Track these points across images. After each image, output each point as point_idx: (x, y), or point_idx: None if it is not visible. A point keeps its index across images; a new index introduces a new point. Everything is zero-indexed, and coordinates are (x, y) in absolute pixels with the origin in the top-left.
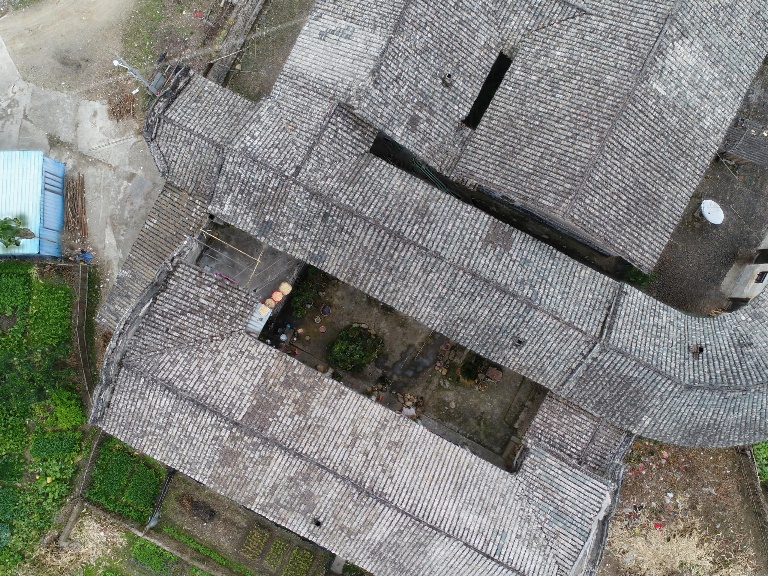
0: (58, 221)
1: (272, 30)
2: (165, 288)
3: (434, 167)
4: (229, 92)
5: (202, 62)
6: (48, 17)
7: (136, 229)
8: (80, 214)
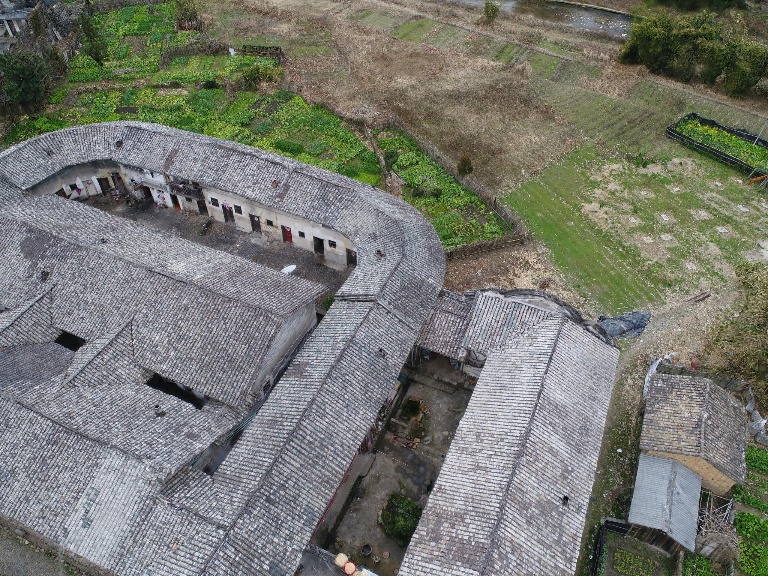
0: None
1: None
2: None
3: (233, 426)
4: None
5: None
6: None
7: None
8: None
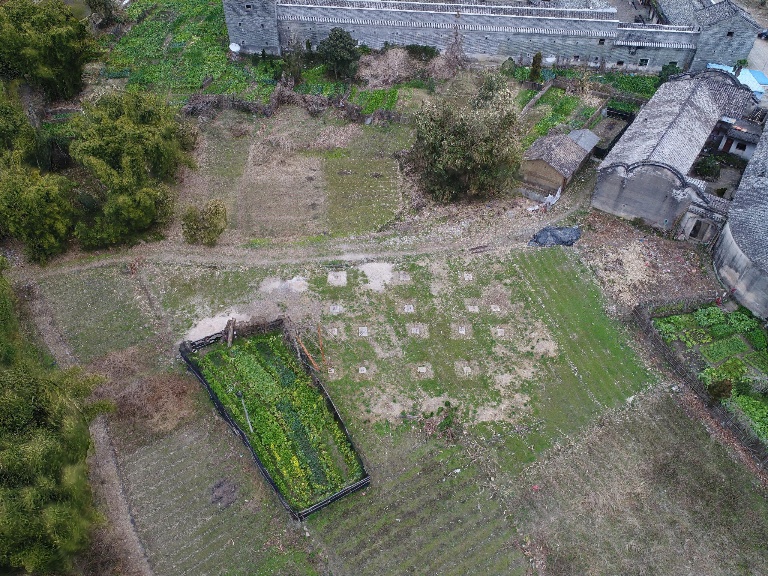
0: None
1: None
2: (739, 89)
3: None
4: None
5: None
6: None
7: None
8: None
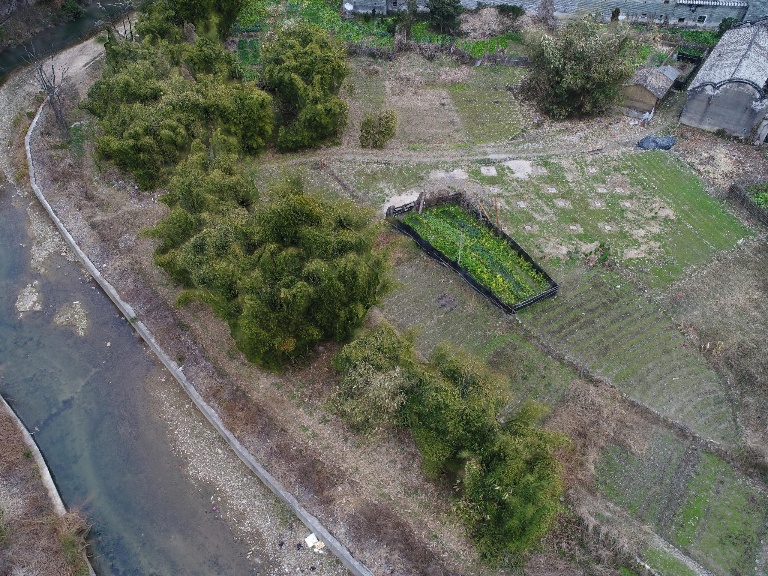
0: None
1: None
2: None
3: None
4: None
5: None
6: None
7: None
8: None
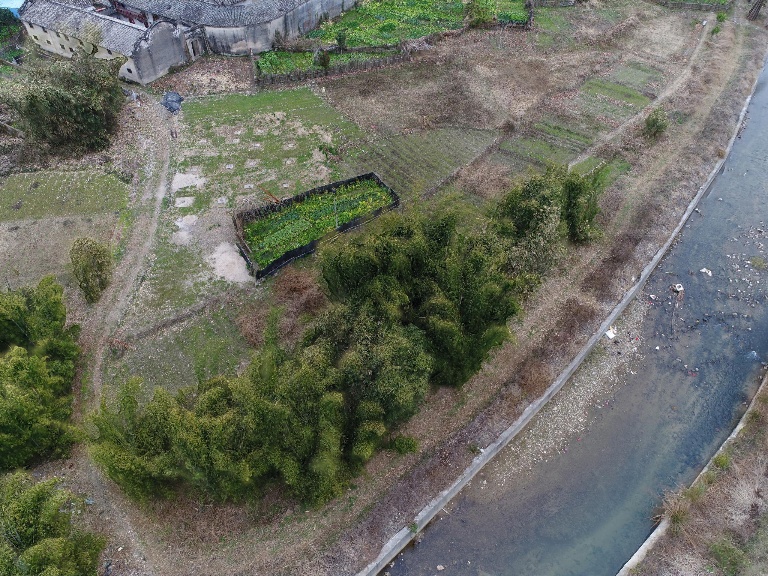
0: None
1: None
2: None
3: None
4: None
5: None
6: None
7: None
8: None
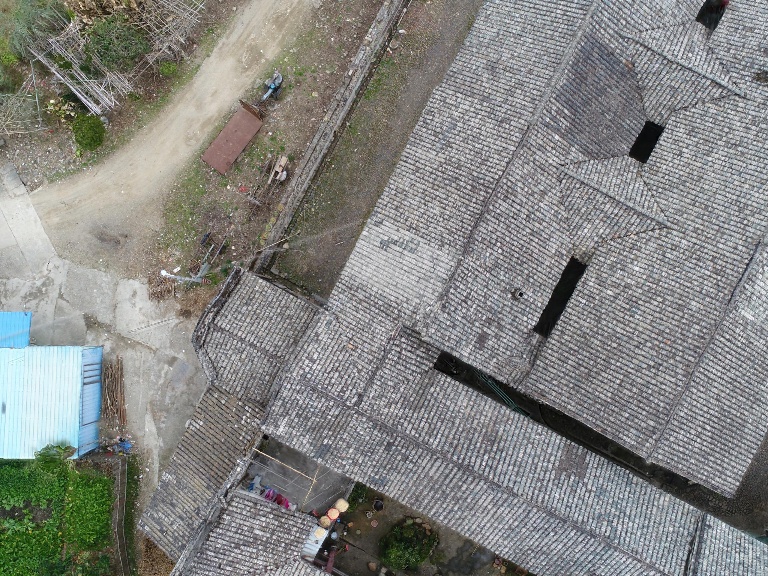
0: (96, 410)
1: (321, 207)
2: (218, 524)
3: (501, 381)
4: (281, 291)
5: (247, 239)
6: (85, 190)
7: (178, 416)
8: (119, 401)
